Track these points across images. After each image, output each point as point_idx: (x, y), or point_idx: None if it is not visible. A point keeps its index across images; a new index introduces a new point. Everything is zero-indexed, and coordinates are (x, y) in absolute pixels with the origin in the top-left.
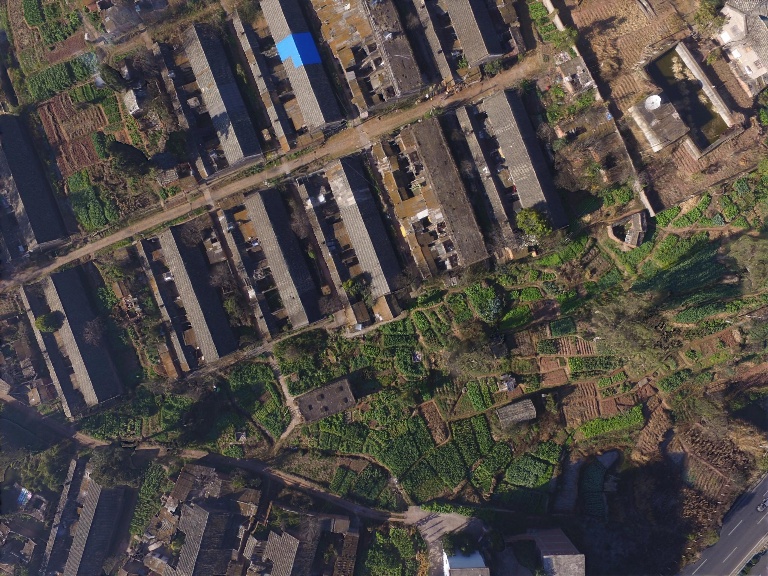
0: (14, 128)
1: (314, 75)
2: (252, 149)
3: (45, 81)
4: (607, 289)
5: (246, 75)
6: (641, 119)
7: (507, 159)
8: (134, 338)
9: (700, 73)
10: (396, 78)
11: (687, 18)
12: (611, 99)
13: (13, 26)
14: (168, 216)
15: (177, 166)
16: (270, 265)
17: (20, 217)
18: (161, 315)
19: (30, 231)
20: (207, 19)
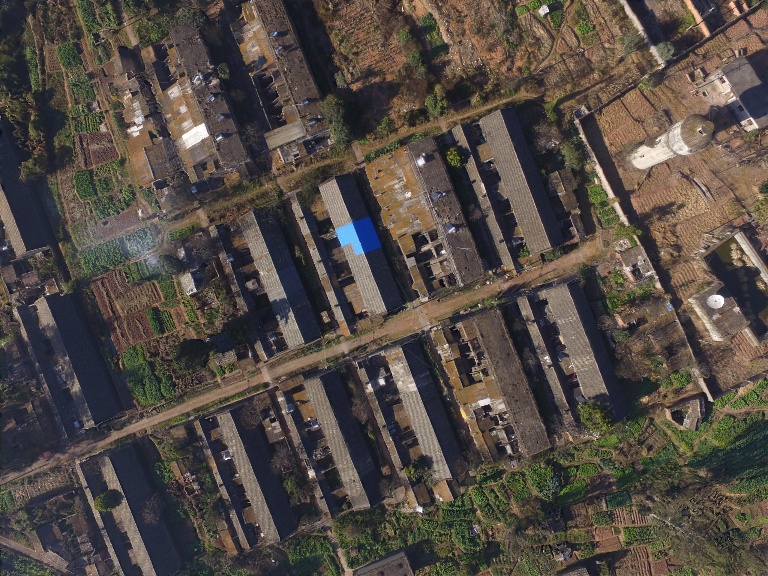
0: (68, 305)
1: (375, 262)
2: (312, 334)
3: (99, 258)
4: (662, 463)
5: (304, 256)
6: (702, 312)
7: (569, 349)
8: (192, 512)
9: (759, 263)
10: (459, 271)
11: (745, 203)
12: (671, 287)
13: (64, 199)
14: (225, 392)
15: (235, 347)
16: (330, 447)
17: (76, 396)
18: (219, 489)
19: (87, 411)
20: (264, 198)
